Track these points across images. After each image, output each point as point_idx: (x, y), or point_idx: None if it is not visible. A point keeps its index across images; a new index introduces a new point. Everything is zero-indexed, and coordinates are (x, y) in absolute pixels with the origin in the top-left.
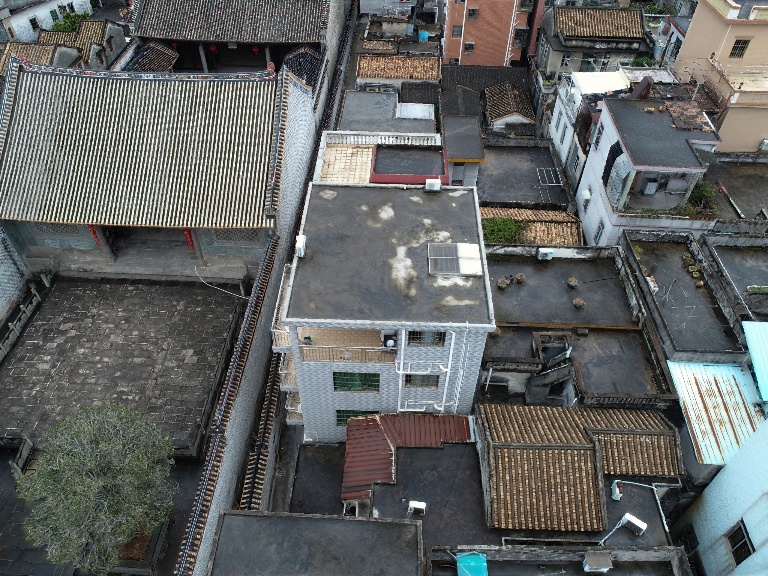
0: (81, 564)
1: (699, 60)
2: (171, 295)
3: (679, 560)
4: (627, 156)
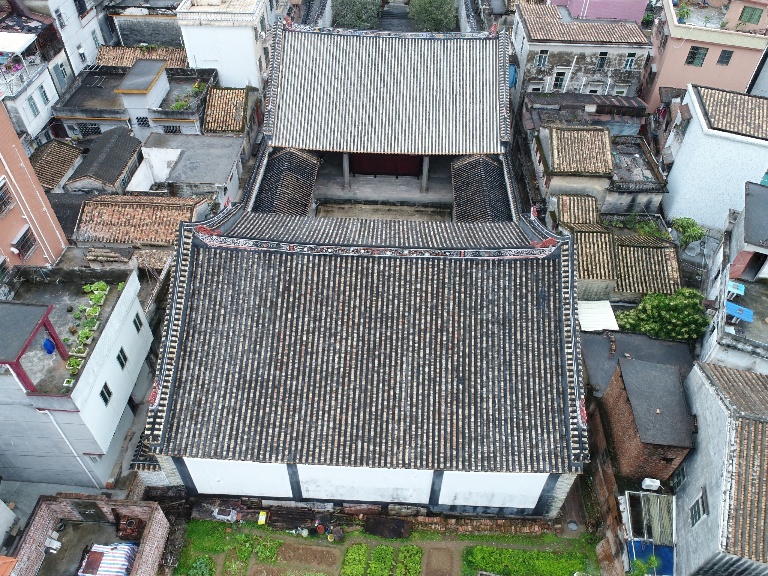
0: None
1: None
2: None
3: None
4: None
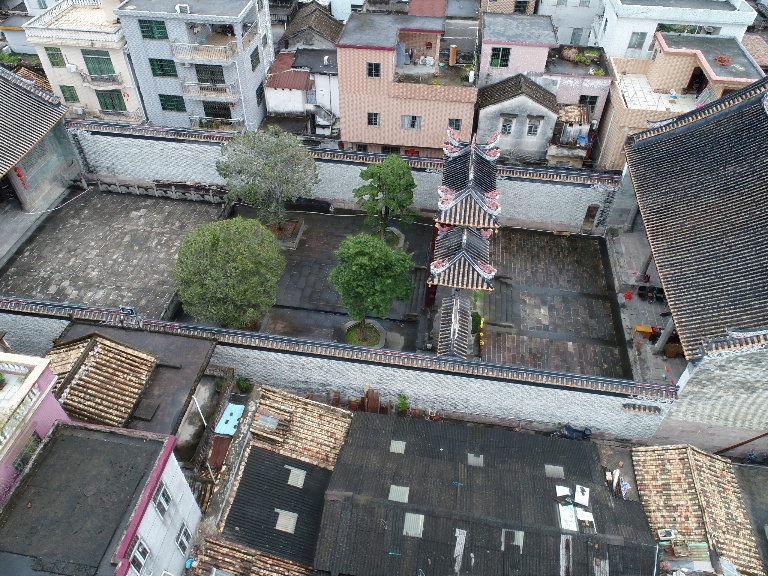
0: (310, 195)
1: None
2: (56, 228)
3: (369, 2)
4: None
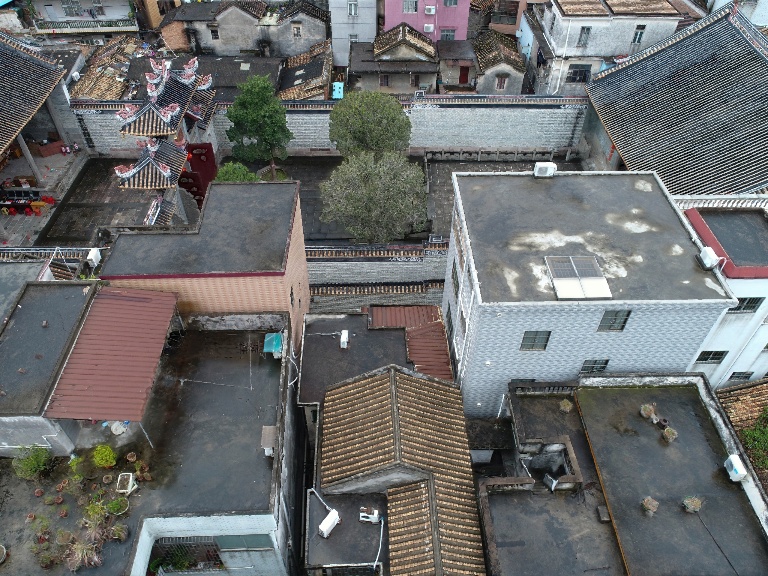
0: None
1: None
2: None
3: None
4: None
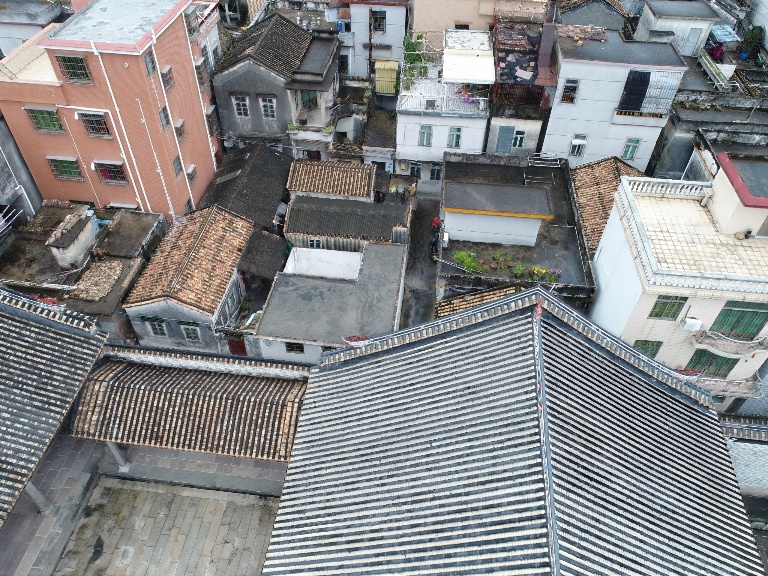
0: None
1: (459, 7)
2: None
3: None
4: (668, 69)
